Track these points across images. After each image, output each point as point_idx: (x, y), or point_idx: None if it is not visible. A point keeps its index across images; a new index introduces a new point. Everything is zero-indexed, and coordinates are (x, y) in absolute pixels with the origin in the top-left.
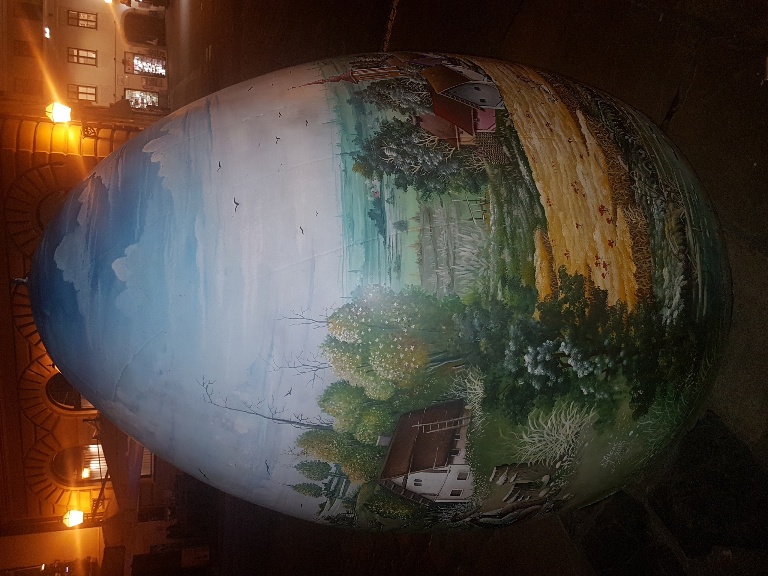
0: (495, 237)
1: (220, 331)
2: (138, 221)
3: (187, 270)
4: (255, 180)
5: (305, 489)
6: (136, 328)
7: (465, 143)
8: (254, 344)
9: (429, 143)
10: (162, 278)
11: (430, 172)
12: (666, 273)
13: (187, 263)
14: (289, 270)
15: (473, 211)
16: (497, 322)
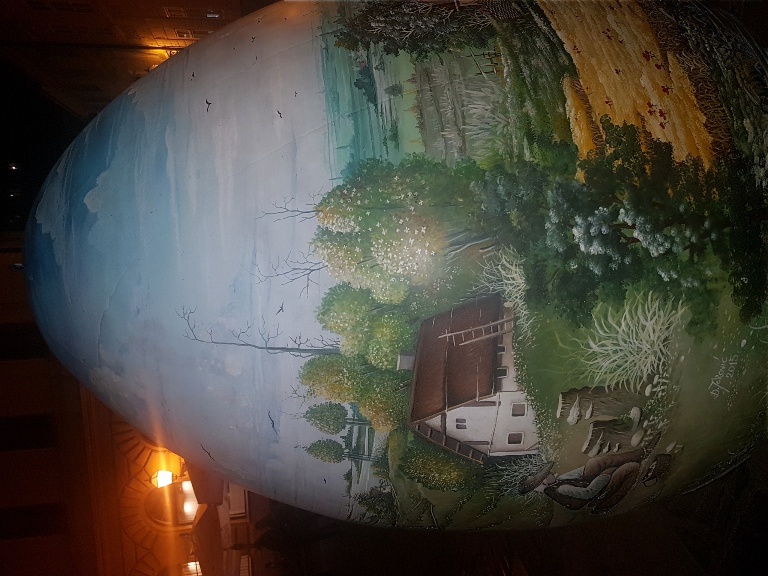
0: (512, 89)
1: (196, 244)
2: (110, 147)
3: (158, 184)
4: (229, 78)
5: (322, 451)
6: (109, 263)
7: (465, 4)
8: (235, 254)
9: (422, 10)
10: (133, 198)
11: (425, 34)
12: (748, 125)
13: (158, 176)
14: (268, 159)
15: (481, 65)
16: (529, 188)
